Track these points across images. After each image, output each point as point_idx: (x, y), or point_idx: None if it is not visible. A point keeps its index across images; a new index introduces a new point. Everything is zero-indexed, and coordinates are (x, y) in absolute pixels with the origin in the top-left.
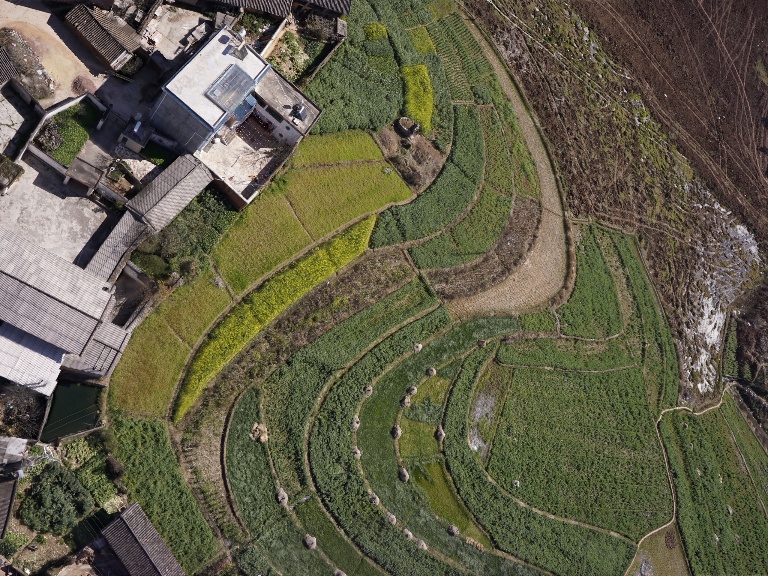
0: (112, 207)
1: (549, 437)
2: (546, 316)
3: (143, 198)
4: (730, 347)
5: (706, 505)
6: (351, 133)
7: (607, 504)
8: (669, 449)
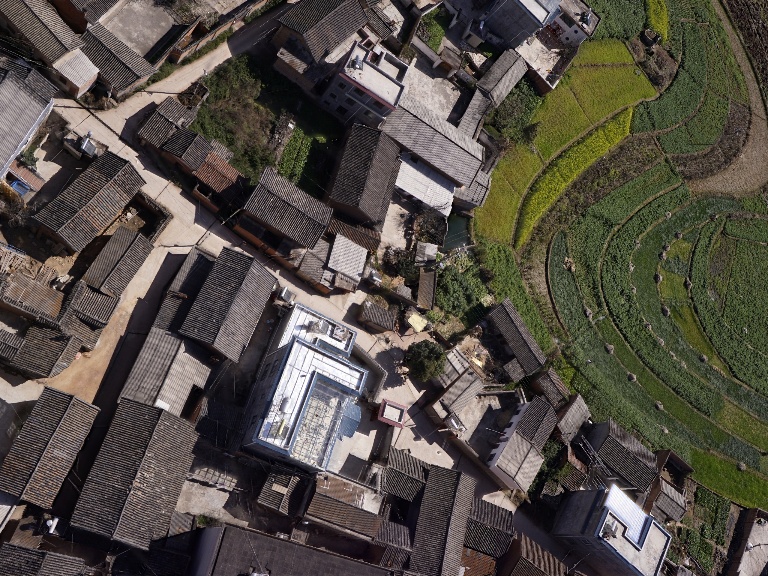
0: (464, 87)
1: (766, 298)
2: (759, 201)
3: (487, 80)
4: None
5: None
6: (610, 41)
7: None
8: None
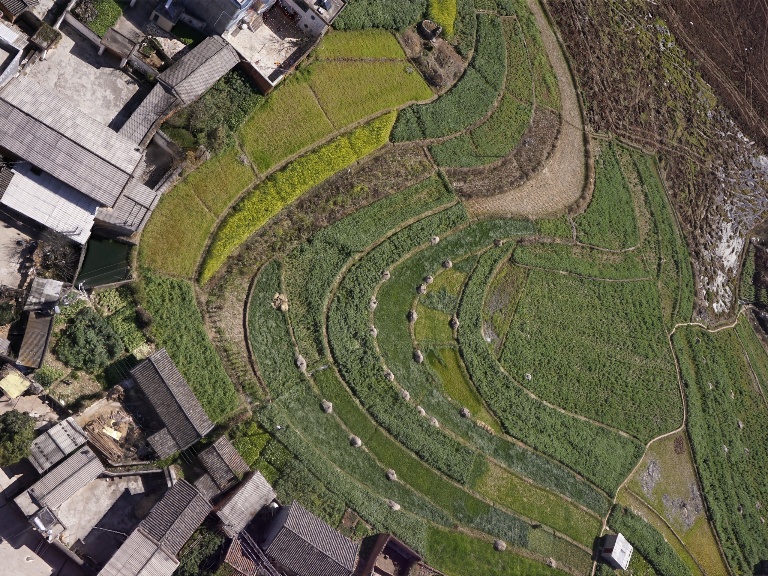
0: (144, 80)
1: (562, 337)
2: (562, 223)
3: (173, 72)
4: (747, 271)
5: (716, 417)
6: (375, 32)
7: (617, 405)
8: (681, 360)
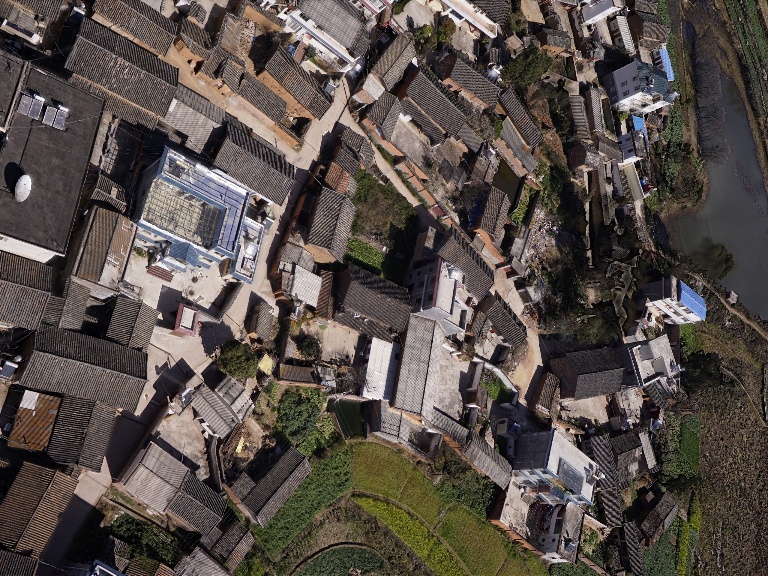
0: (465, 422)
1: None
2: None
3: (479, 439)
4: None
5: None
6: None
7: None
8: None
